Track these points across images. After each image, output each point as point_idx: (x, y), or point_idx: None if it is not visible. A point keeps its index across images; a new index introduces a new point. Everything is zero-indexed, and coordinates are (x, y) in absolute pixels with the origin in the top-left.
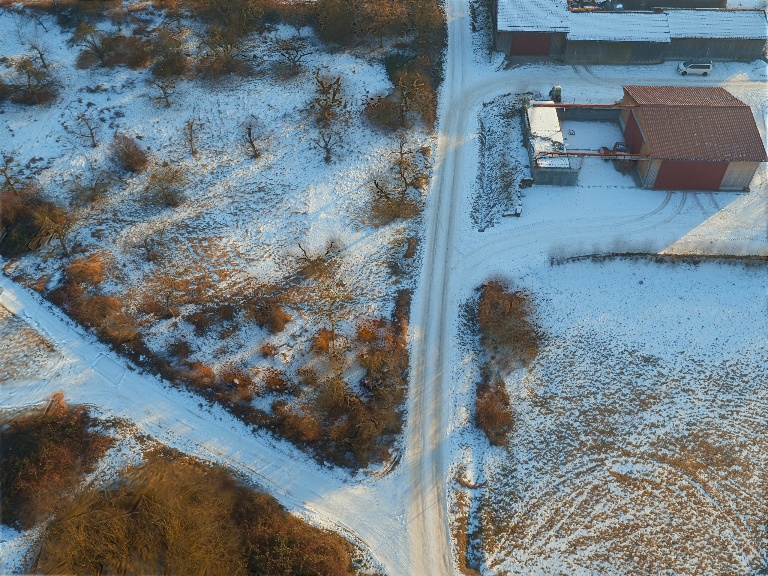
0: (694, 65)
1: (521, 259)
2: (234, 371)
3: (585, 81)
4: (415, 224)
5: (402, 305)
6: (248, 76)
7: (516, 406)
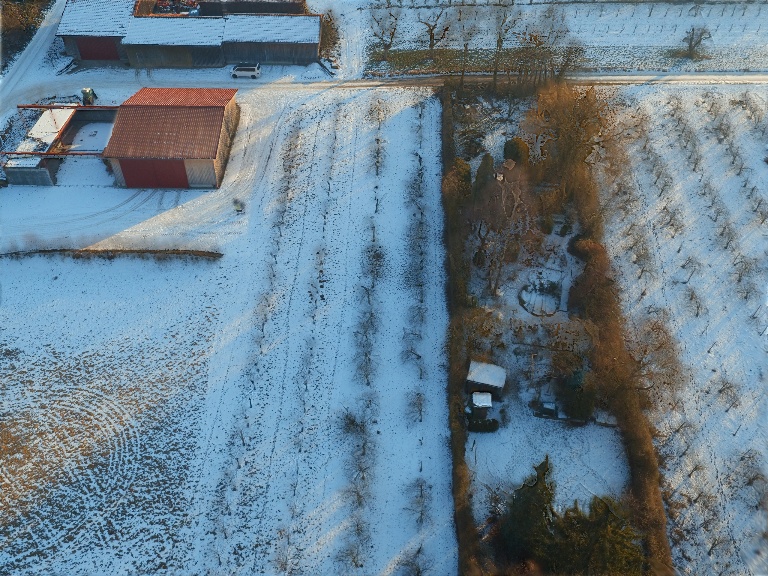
0: (240, 68)
1: None
2: None
3: (137, 84)
4: None
5: None
6: None
7: None
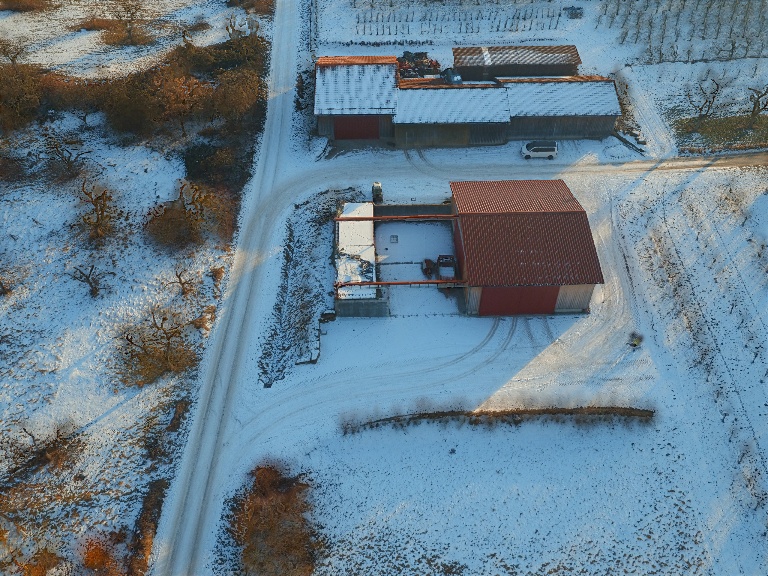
0: (537, 148)
1: (309, 427)
2: None
3: (416, 171)
4: (189, 380)
5: (148, 509)
6: (16, 181)
7: None
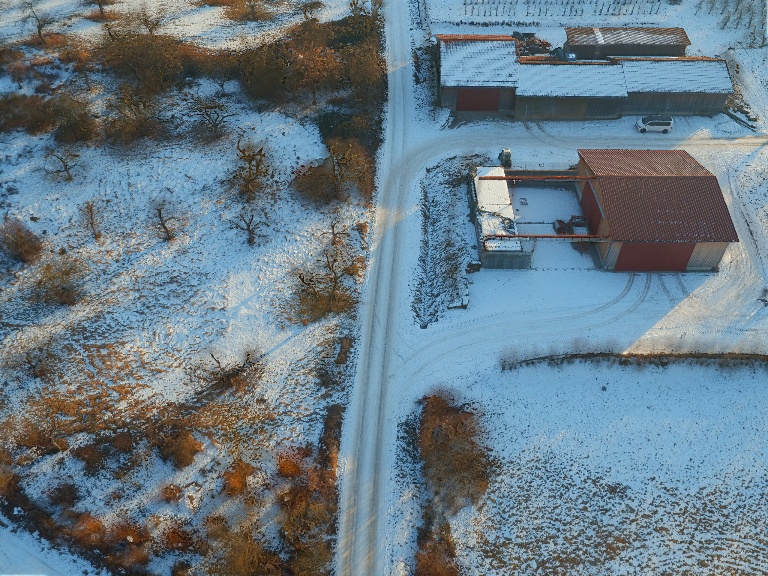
0: (653, 122)
1: (468, 363)
2: (129, 522)
3: (537, 140)
4: (349, 320)
5: (331, 428)
6: (164, 140)
7: (463, 558)
